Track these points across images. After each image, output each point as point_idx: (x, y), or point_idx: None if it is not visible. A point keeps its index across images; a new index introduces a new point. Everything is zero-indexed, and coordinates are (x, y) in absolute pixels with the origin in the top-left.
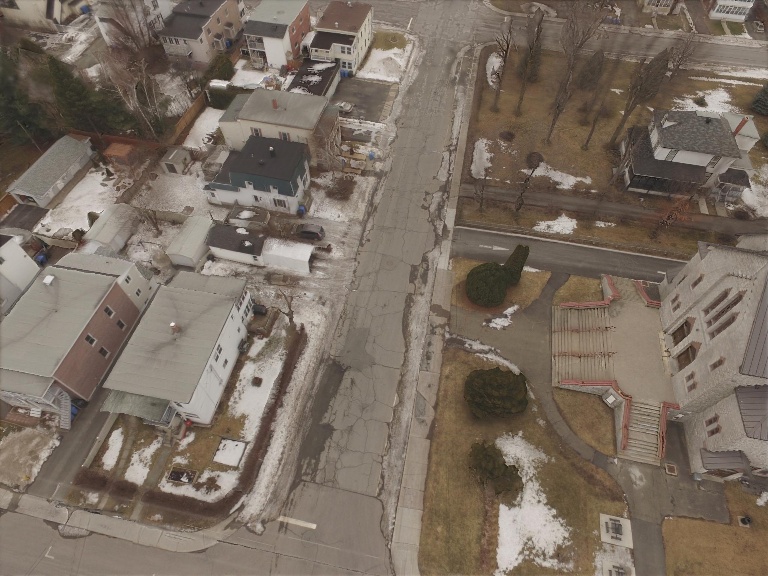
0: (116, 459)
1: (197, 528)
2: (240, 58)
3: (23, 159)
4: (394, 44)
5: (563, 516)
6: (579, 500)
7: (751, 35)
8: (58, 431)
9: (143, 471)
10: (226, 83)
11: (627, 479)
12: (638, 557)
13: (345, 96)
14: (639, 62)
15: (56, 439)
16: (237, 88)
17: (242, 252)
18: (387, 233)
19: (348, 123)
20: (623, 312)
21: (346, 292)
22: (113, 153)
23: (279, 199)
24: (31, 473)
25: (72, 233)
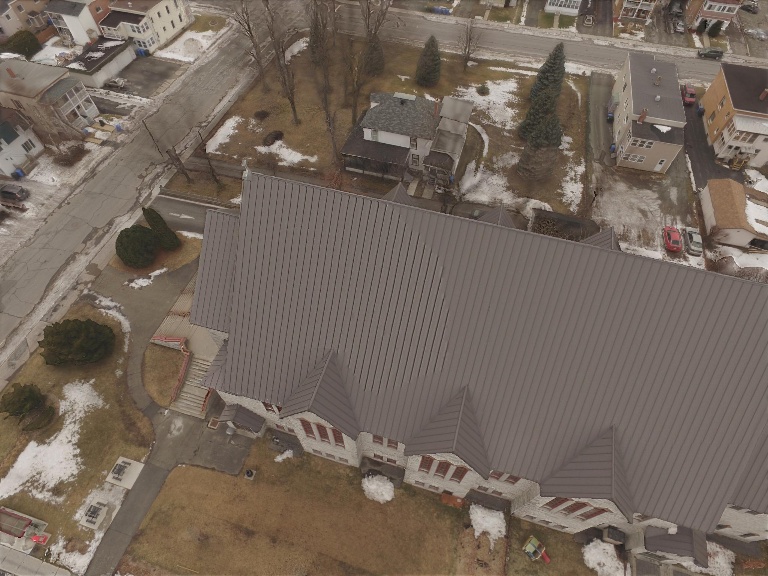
0: None
1: None
2: (56, 35)
3: None
4: (211, 27)
5: (83, 456)
6: (107, 443)
7: (579, 29)
8: None
9: None
10: (14, 56)
11: (166, 428)
12: (130, 497)
13: (131, 73)
14: (446, 51)
15: None
16: None
17: None
18: (90, 198)
19: (118, 97)
20: None
21: (17, 248)
22: None
23: None
24: None
25: None
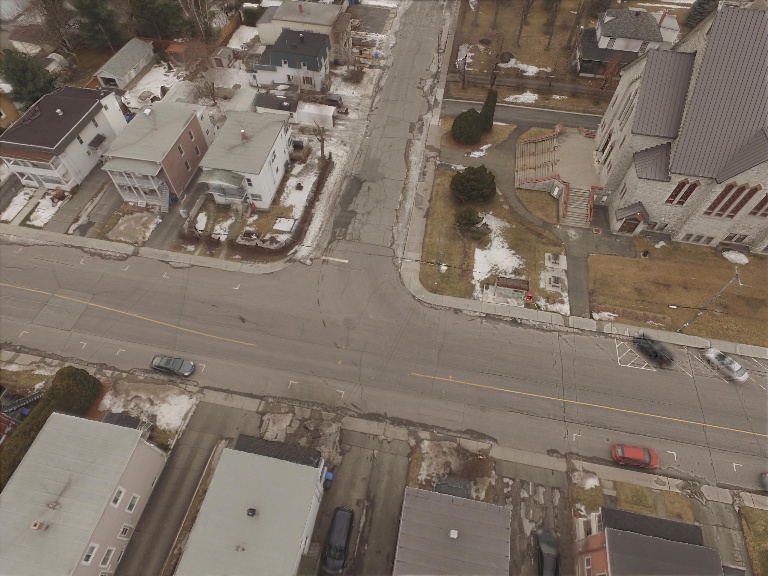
0: (204, 228)
1: (266, 262)
2: None
3: (98, 60)
4: None
5: (519, 254)
6: (531, 246)
7: None
8: (160, 214)
9: None
10: (256, 5)
11: (565, 236)
12: (570, 274)
13: (353, 17)
14: None
15: (159, 218)
16: (266, 8)
17: (282, 110)
18: (391, 103)
19: (357, 35)
20: (567, 140)
21: (361, 138)
22: (173, 50)
23: (307, 77)
24: (145, 235)
25: (151, 99)
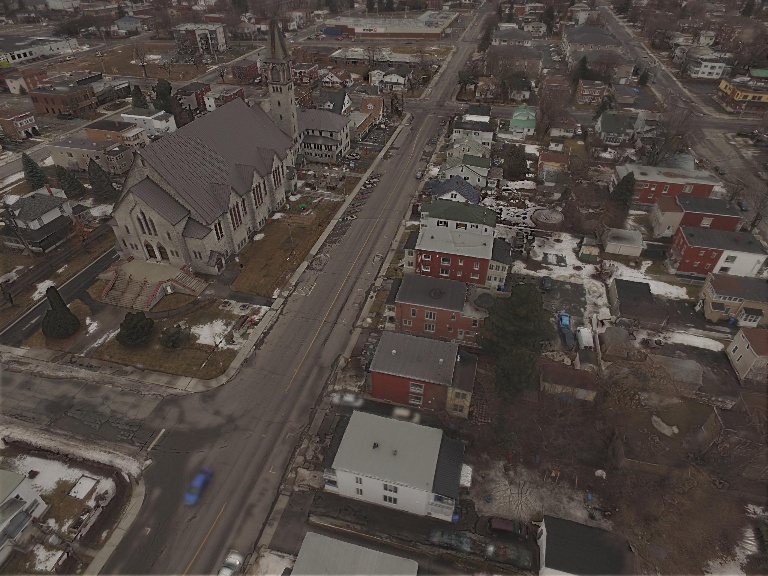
0: None
1: (128, 502)
2: None
3: None
4: None
5: (213, 320)
6: (209, 313)
7: None
8: None
9: (58, 555)
10: None
11: (209, 296)
12: (240, 300)
13: None
14: None
15: None
16: None
17: None
18: None
19: None
20: (126, 271)
21: None
22: None
23: None
24: None
25: None
